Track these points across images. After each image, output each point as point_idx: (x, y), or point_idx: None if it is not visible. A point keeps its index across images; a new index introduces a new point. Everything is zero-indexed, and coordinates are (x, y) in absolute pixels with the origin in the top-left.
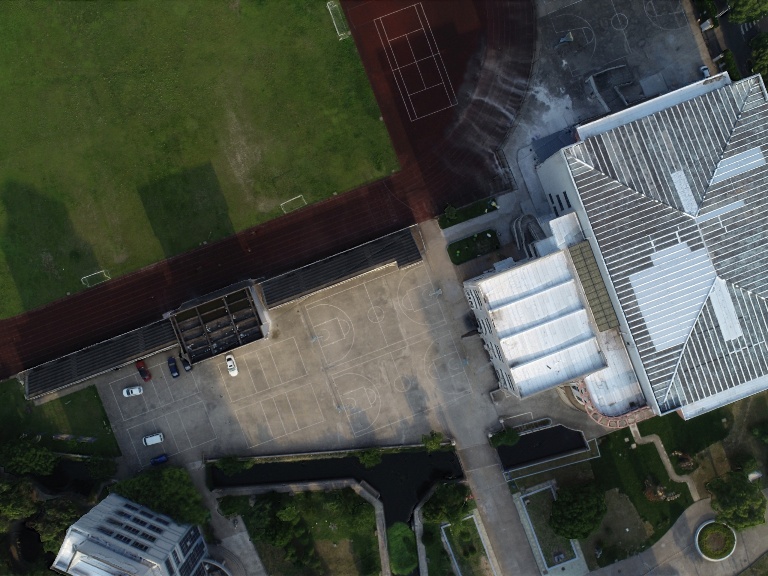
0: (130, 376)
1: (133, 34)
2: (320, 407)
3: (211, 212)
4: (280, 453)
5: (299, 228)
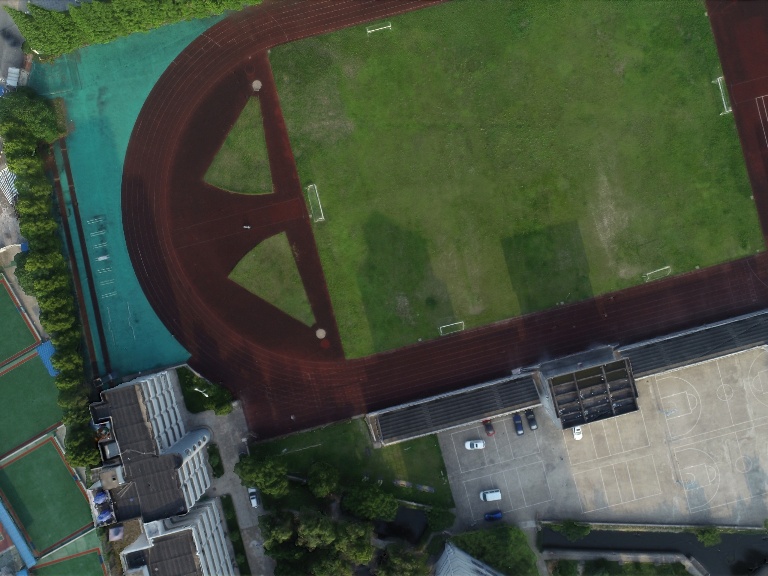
0: (473, 429)
1: (514, 88)
2: (659, 479)
3: (572, 273)
4: (614, 521)
5: (657, 298)
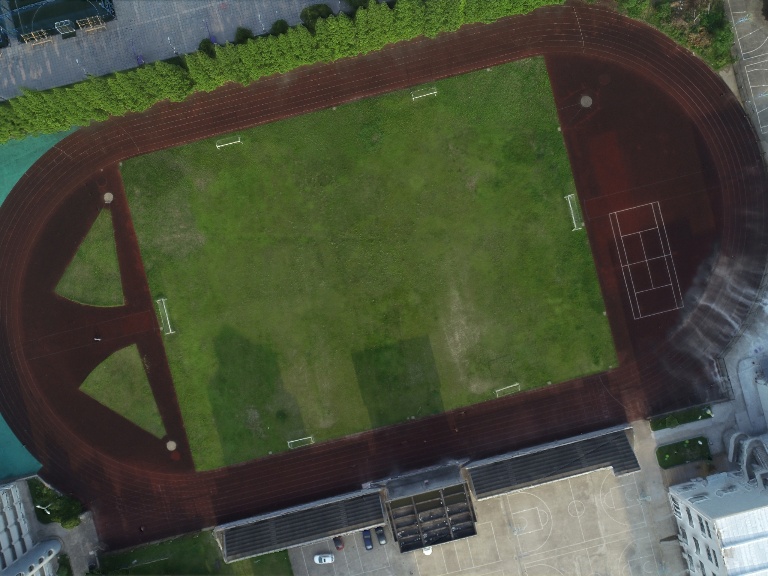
0: (322, 542)
1: (366, 202)
2: None
3: (423, 388)
4: None
5: (509, 413)
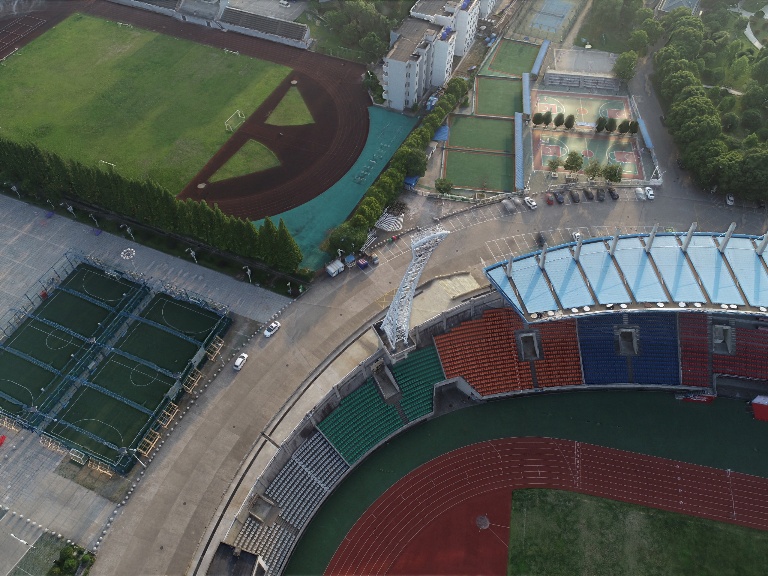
0: None
1: (84, 111)
2: None
3: (158, 44)
4: None
5: None
